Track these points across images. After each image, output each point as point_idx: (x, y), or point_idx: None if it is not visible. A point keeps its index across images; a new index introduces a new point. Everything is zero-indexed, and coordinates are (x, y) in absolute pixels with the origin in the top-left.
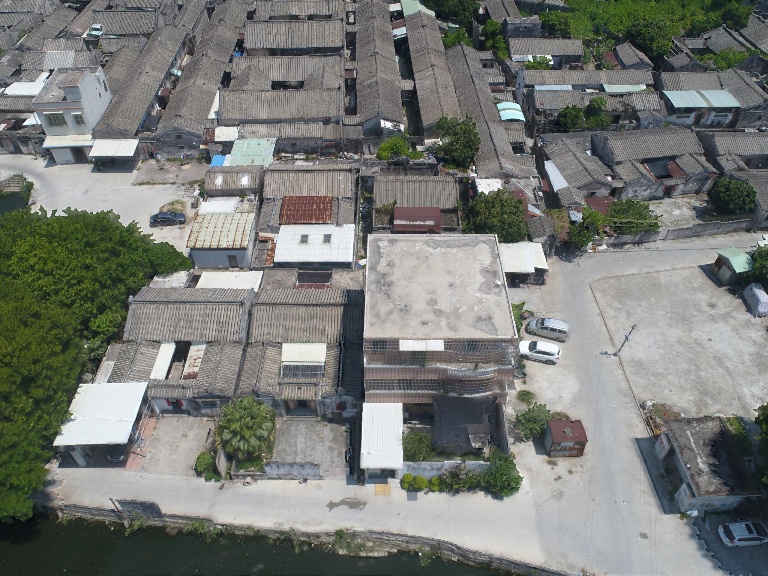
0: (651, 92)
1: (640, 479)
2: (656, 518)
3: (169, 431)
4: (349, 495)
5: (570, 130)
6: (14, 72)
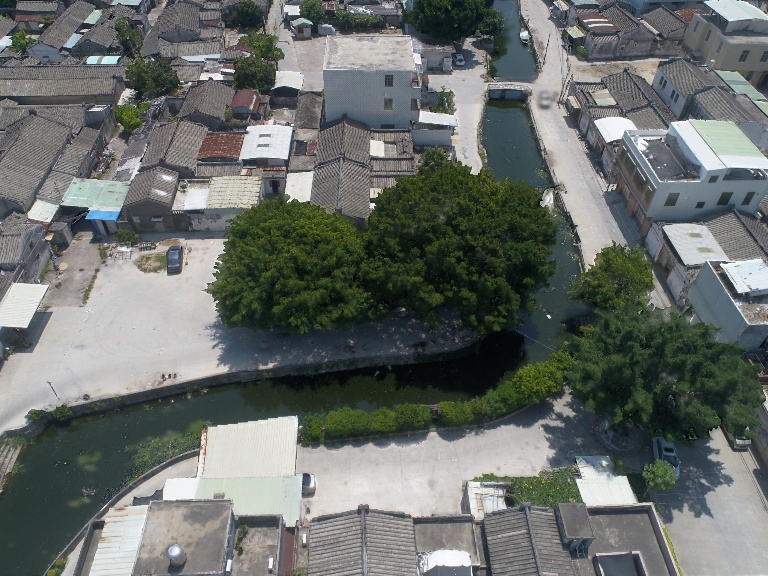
0: (114, 7)
1: (436, 77)
2: (454, 77)
3: None
4: (459, 152)
5: (139, 46)
6: None
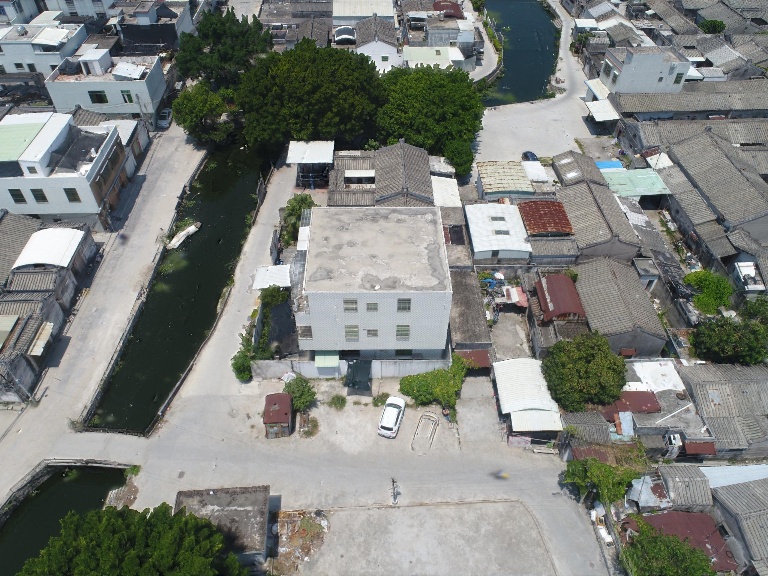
0: None
1: None
2: None
3: (321, 199)
4: None
5: None
6: (692, 46)
